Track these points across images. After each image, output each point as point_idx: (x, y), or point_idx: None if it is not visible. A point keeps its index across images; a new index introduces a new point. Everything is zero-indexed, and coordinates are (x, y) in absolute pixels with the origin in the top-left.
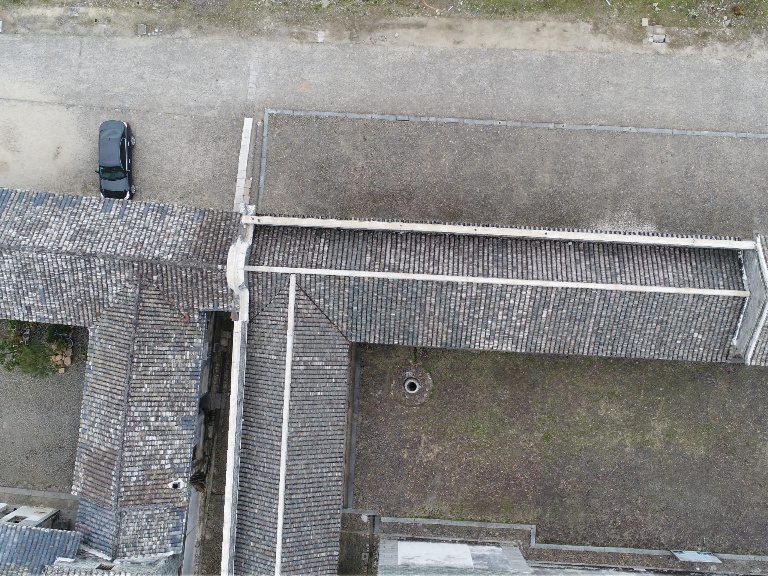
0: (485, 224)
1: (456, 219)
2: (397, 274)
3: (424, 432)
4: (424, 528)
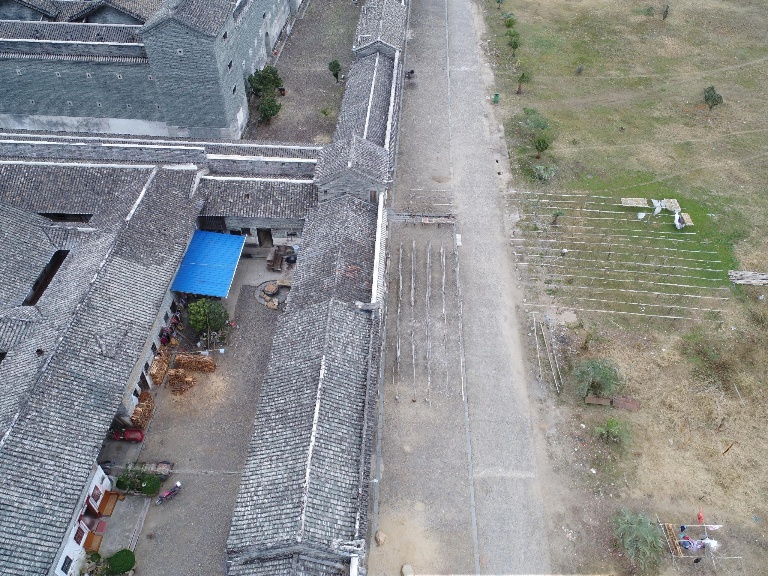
0: None
1: None
2: None
3: (339, 5)
4: None
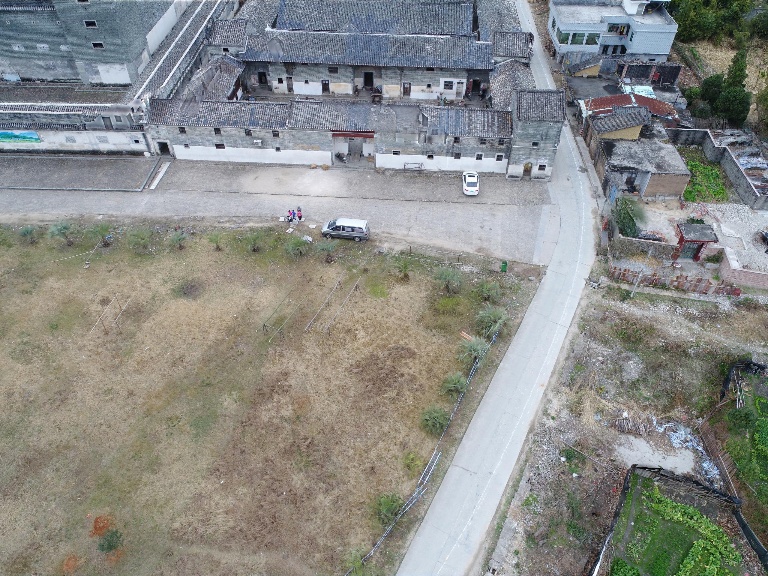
0: (41, 127)
1: (61, 160)
2: (85, 105)
3: None
4: (121, 90)
